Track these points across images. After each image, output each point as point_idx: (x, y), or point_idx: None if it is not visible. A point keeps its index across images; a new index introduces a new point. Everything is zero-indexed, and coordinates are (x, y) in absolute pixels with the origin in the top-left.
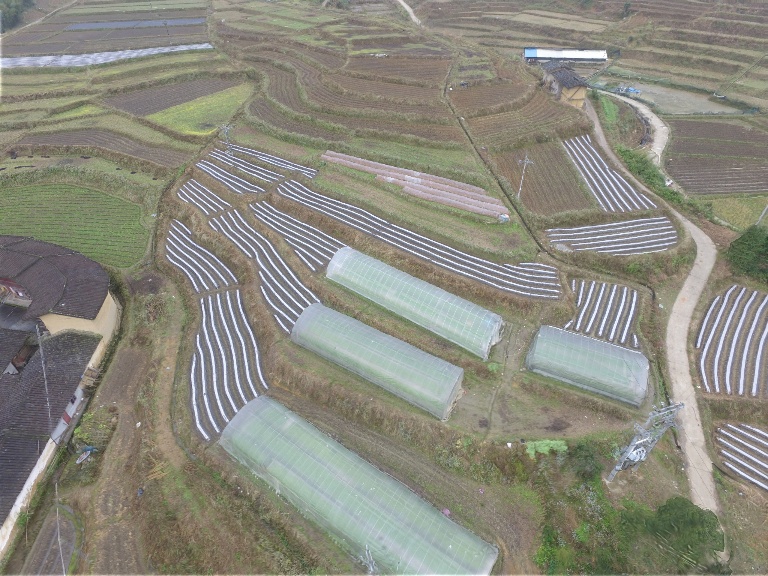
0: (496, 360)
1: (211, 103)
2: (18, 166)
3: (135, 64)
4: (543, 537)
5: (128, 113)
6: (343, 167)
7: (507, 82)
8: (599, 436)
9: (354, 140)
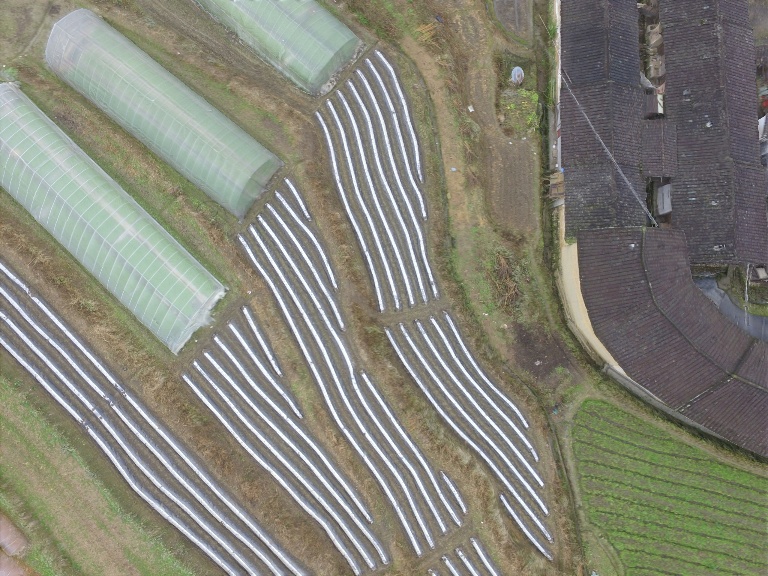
0: None
1: None
2: None
3: None
4: None
5: None
6: None
7: None
8: None
9: None
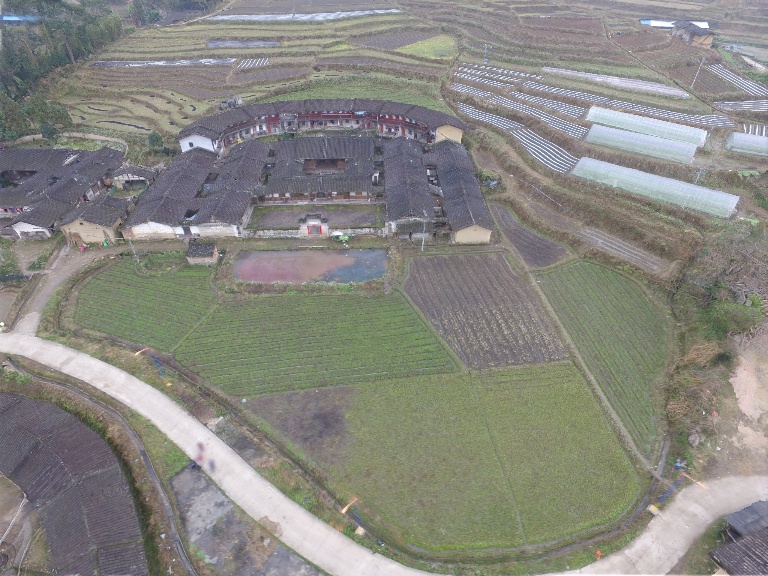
0: None
1: (431, 44)
2: (326, 75)
3: (354, 21)
4: (757, 197)
5: (378, 48)
6: None
7: (650, 34)
8: None
9: (559, 62)
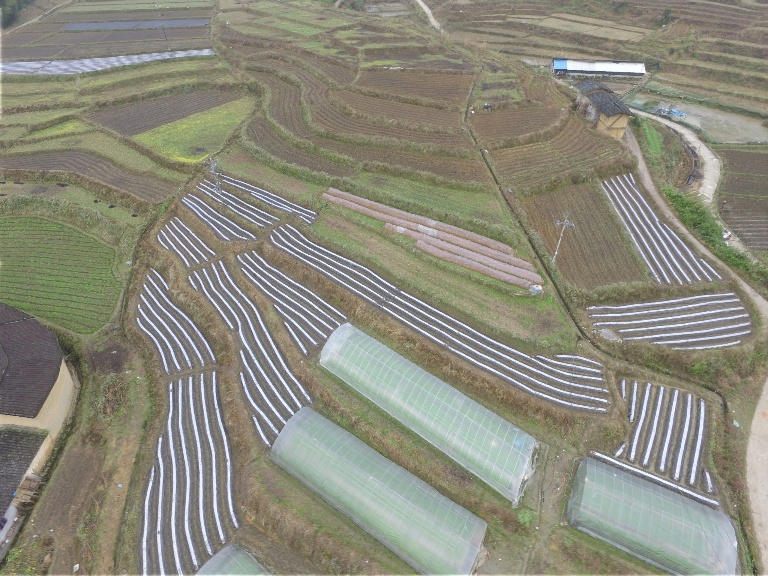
0: (528, 505)
1: (206, 121)
2: None
3: (129, 72)
4: None
5: (114, 132)
6: (347, 210)
7: (536, 105)
8: None
9: (361, 175)
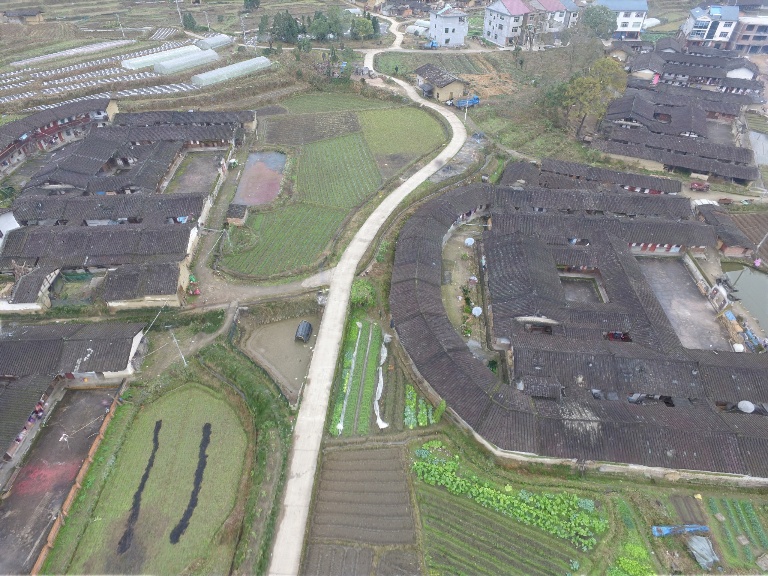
0: None
1: None
2: None
3: None
4: None
5: None
6: None
7: None
8: (236, 48)
9: None
